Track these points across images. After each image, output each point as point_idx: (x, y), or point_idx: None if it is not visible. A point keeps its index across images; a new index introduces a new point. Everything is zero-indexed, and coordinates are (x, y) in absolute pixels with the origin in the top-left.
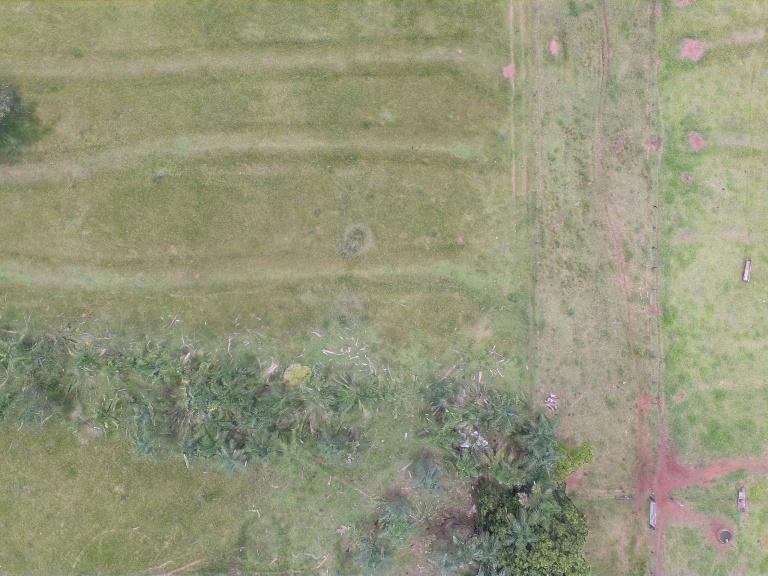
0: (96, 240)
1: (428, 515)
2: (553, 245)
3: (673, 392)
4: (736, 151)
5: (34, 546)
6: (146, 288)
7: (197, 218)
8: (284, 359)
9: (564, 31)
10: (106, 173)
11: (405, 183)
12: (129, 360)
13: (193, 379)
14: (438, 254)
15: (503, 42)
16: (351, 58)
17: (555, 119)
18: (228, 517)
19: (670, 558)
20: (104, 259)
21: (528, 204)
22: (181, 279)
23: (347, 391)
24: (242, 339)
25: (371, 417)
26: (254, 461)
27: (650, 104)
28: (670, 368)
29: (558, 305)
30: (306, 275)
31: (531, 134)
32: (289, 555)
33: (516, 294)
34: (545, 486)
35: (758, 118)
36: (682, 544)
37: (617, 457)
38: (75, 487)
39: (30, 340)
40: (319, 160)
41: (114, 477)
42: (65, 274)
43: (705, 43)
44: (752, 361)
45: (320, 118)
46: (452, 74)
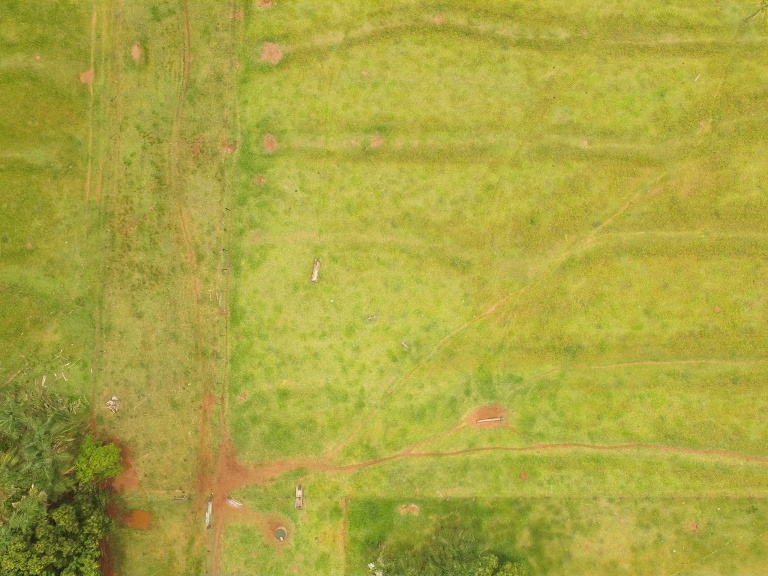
0: None
1: None
2: (124, 249)
3: (236, 392)
4: (311, 153)
5: None
6: None
7: None
8: None
9: (146, 36)
10: None
11: None
12: None
13: None
14: (9, 260)
15: (83, 48)
16: None
17: (133, 124)
18: None
19: (227, 557)
20: None
21: (100, 208)
22: None
23: None
24: None
25: None
26: None
27: (228, 107)
28: (235, 369)
29: (127, 308)
30: None
31: (108, 139)
32: None
33: (84, 298)
34: (42, 489)
35: (334, 120)
36: (239, 543)
37: (178, 458)
38: None
39: None
40: None
41: None
42: None
43: (284, 46)
44: (317, 360)
45: None
46: (32, 80)
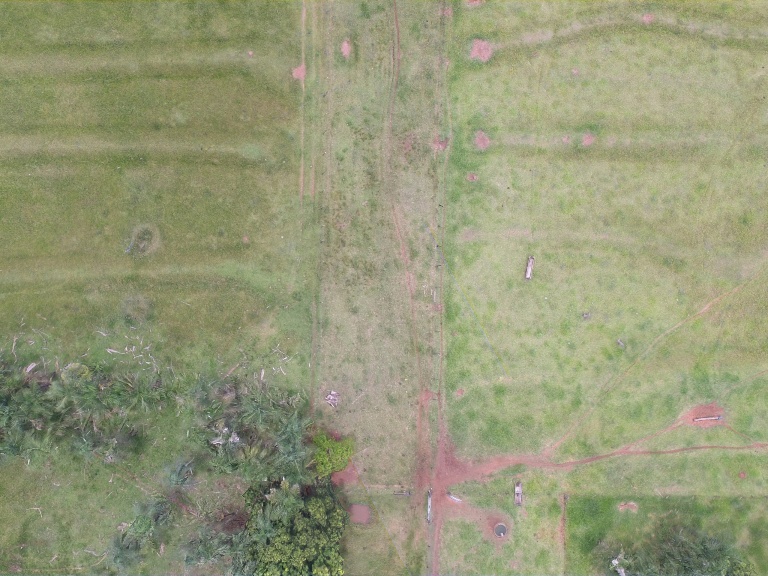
0: None
1: (208, 511)
2: (339, 244)
3: (453, 388)
4: (522, 150)
5: None
6: None
7: None
8: (68, 358)
9: (355, 33)
10: None
11: (193, 183)
12: None
13: None
14: (225, 253)
15: (294, 44)
16: (143, 60)
17: (345, 119)
18: (9, 515)
19: (447, 552)
20: None
21: (315, 204)
22: None
23: (130, 389)
24: (27, 339)
25: (154, 415)
26: (37, 459)
27: (439, 104)
28: (451, 365)
29: (343, 303)
30: (93, 275)
31: (320, 134)
32: (69, 552)
33: (300, 293)
34: (293, 481)
35: (544, 118)
36: (459, 538)
37: (397, 453)
38: None
39: None
40: (109, 161)
41: None
42: None
43: (494, 44)
44: (532, 357)
45: (111, 120)
46: (243, 75)
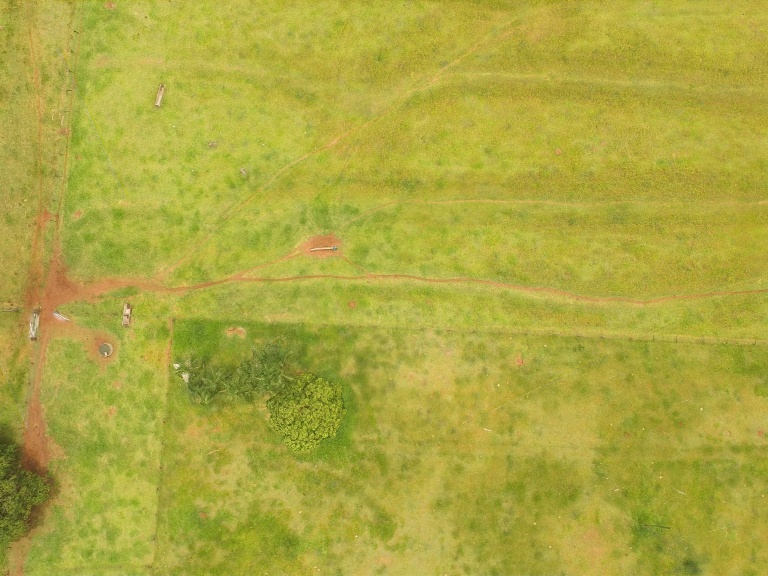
0: None
1: None
2: None
3: (71, 210)
4: None
5: None
6: None
7: None
8: None
9: None
10: None
11: None
12: None
13: None
14: None
15: None
16: None
17: None
18: None
19: (51, 370)
20: None
21: None
22: None
23: None
24: None
25: None
26: None
27: None
28: (72, 187)
29: None
30: None
31: None
32: None
33: None
34: None
35: None
36: (64, 357)
37: (9, 271)
38: None
39: None
40: None
41: None
42: None
43: None
44: (155, 183)
45: None
46: None
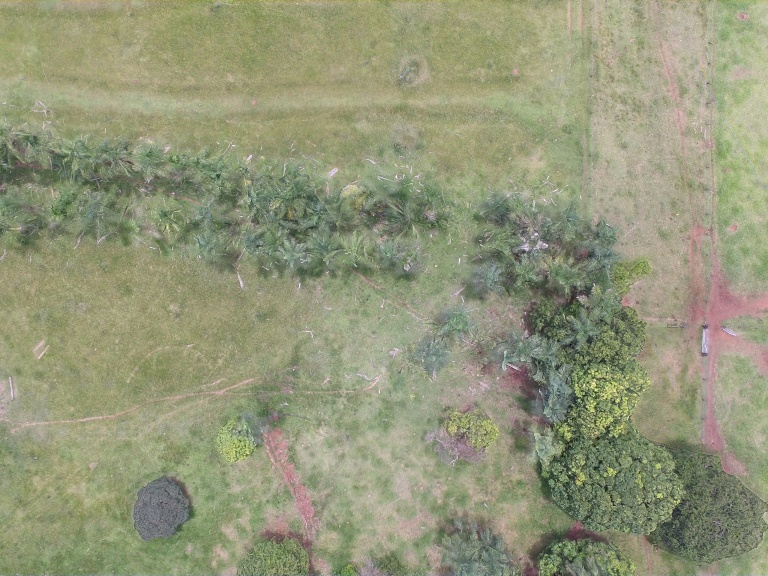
0: (154, 66)
1: (480, 339)
2: (608, 79)
3: (726, 224)
4: None
5: (89, 361)
6: (203, 113)
7: (254, 47)
8: (339, 184)
9: None
10: (164, 2)
11: (461, 16)
12: (192, 159)
13: (255, 179)
14: (493, 86)
15: None
16: None
17: None
18: (281, 337)
19: (722, 386)
20: (161, 85)
21: (583, 39)
22: (237, 105)
23: (401, 217)
24: (297, 164)
25: (425, 243)
26: (308, 283)
27: None
28: (723, 201)
29: (612, 138)
30: (361, 104)
31: None
32: (342, 375)
33: (570, 126)
34: (605, 287)
35: None
36: (734, 372)
37: (670, 286)
38: (130, 304)
39: (87, 161)
40: None
41: (169, 295)
42: (123, 98)
43: None
44: None
45: None
46: None
